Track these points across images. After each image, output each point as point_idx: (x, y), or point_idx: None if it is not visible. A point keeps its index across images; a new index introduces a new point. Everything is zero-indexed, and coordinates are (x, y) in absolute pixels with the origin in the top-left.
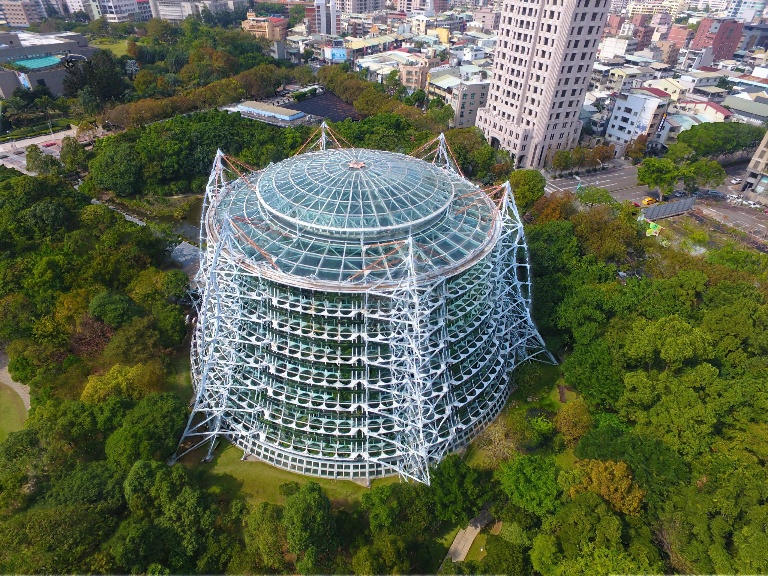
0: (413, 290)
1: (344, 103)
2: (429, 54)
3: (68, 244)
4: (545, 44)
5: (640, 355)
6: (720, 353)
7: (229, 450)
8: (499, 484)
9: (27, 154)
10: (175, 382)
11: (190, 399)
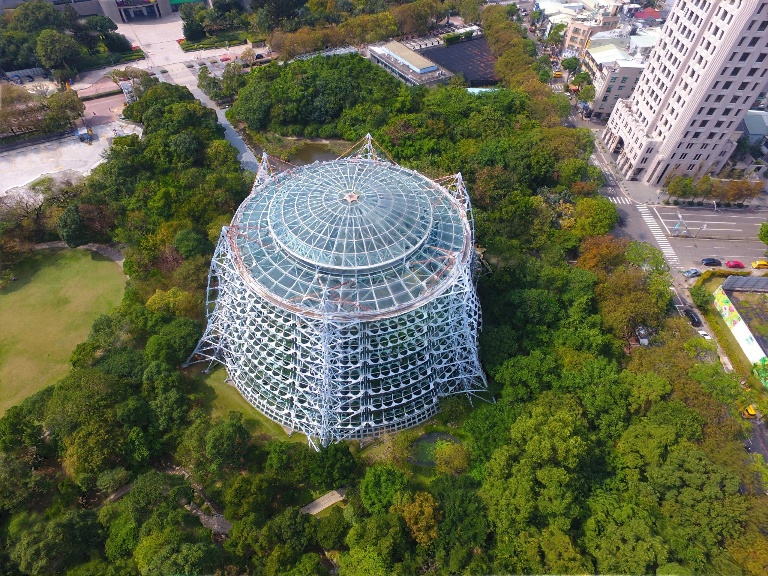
0: (330, 323)
1: (492, 55)
2: (609, 10)
3: (183, 179)
4: (706, 48)
5: (512, 437)
6: (618, 464)
7: (221, 371)
8: (363, 477)
9: (199, 74)
10: (213, 308)
11: None
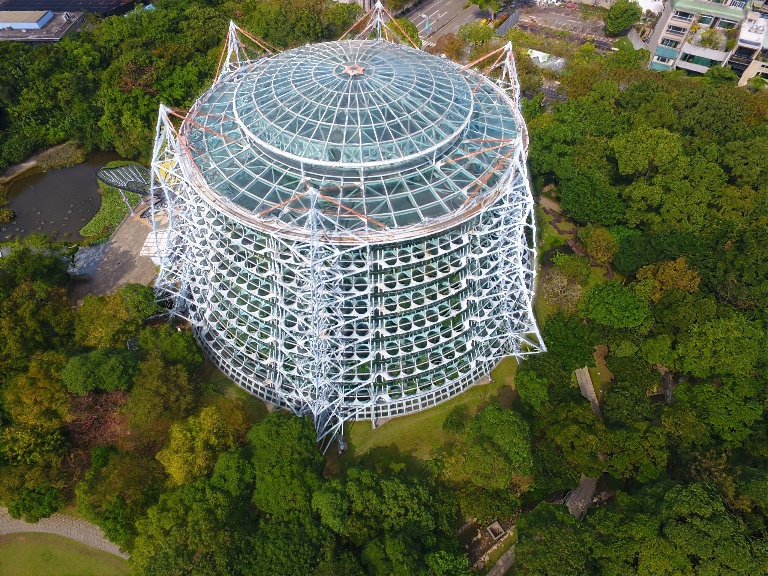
0: None
1: None
2: None
3: None
4: None
5: (640, 170)
6: None
7: (354, 428)
8: (591, 320)
9: None
10: None
11: (266, 409)
